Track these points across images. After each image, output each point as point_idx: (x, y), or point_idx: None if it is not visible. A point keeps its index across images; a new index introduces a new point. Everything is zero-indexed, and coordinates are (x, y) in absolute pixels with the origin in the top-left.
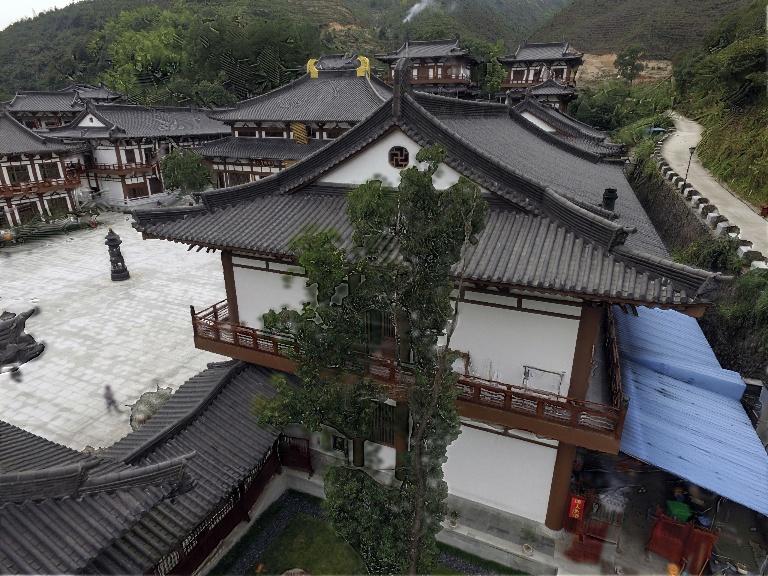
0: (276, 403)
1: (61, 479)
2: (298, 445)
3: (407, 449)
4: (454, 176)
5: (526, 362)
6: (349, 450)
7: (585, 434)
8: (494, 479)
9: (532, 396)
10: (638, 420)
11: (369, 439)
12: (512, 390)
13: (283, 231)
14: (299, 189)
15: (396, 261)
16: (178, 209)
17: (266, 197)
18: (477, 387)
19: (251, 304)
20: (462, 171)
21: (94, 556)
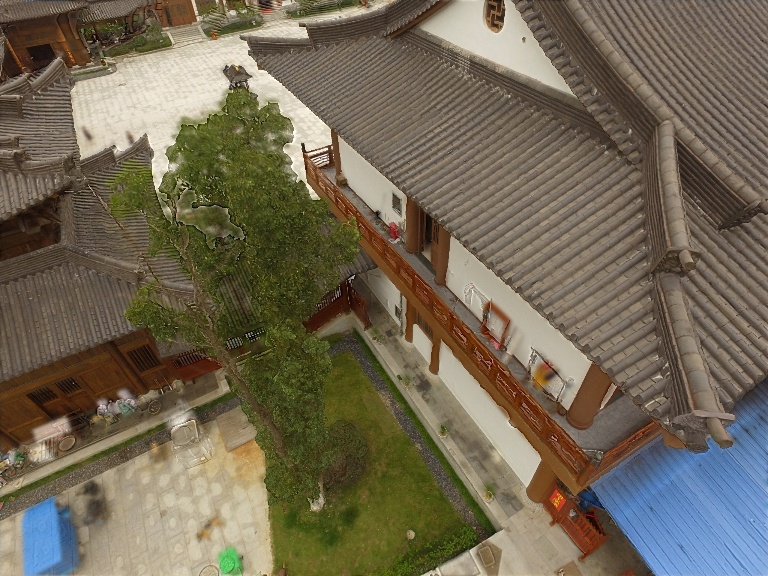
0: (140, 306)
1: (128, 272)
2: (359, 300)
3: (439, 351)
4: (549, 61)
5: (538, 344)
6: (403, 323)
7: (549, 454)
8: (495, 423)
9: (514, 384)
10: (674, 476)
11: (418, 324)
12: (499, 366)
13: (348, 94)
14: (400, 34)
15: (403, 176)
16: (286, 41)
17: (370, 38)
18: (471, 342)
19: (347, 157)
20: (552, 58)
21: (134, 330)
